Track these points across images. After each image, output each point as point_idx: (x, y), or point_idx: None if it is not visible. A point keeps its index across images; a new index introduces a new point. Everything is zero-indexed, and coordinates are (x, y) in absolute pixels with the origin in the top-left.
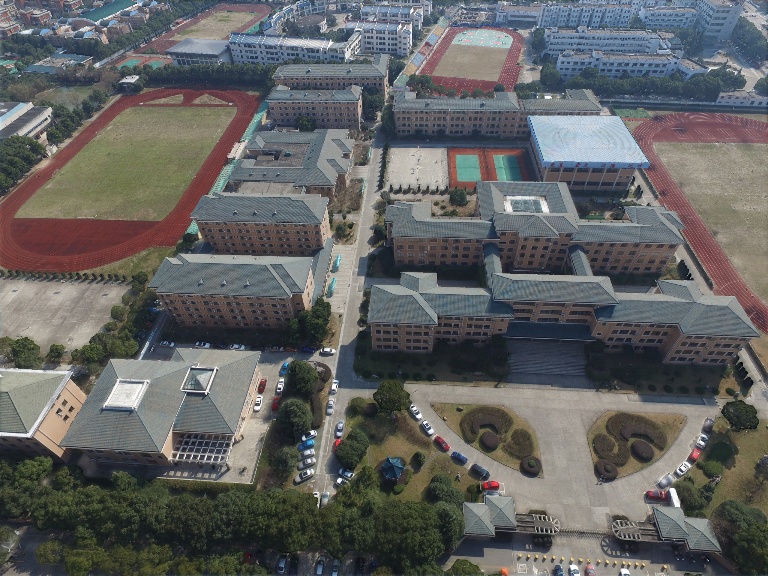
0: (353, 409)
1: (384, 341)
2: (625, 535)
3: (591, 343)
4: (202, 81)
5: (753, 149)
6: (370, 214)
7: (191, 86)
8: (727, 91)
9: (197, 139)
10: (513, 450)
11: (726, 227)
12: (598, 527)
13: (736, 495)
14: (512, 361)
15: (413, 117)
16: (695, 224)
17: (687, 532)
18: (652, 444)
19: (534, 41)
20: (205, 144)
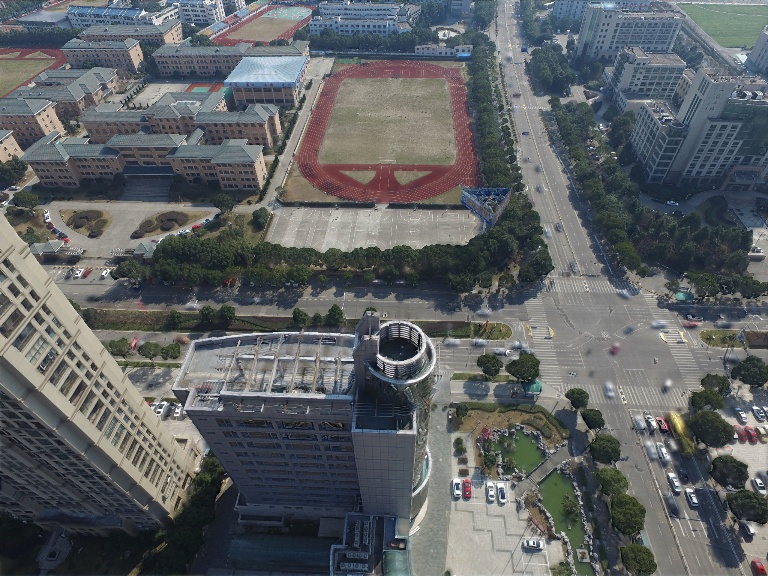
0: (7, 211)
1: (46, 178)
2: (115, 254)
3: (173, 176)
4: (41, 43)
5: (411, 82)
6: None
7: (31, 46)
8: (423, 44)
9: (11, 80)
10: (91, 227)
11: (340, 125)
12: (111, 256)
13: None
14: (126, 190)
15: (169, 61)
16: (321, 123)
17: (147, 250)
18: (177, 224)
19: None
20: (15, 82)
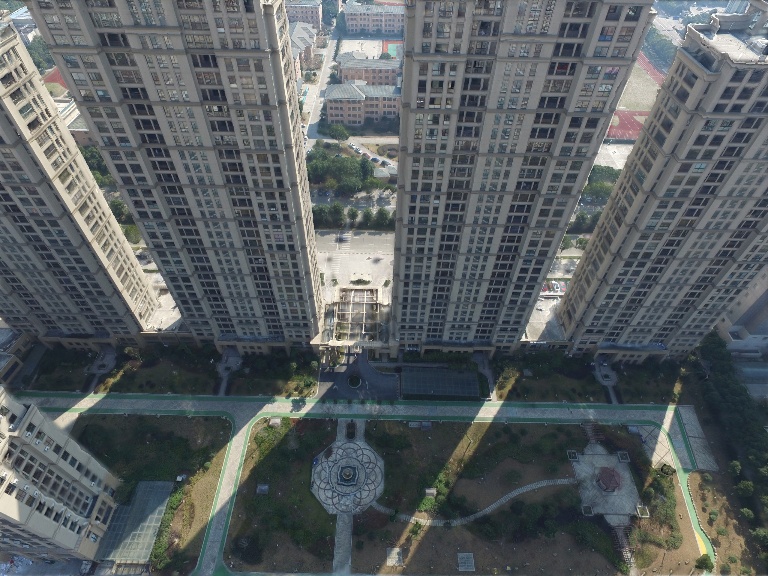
0: (317, 144)
1: (335, 117)
2: None
3: None
4: None
5: None
6: (328, 71)
7: None
8: None
9: None
10: None
11: None
12: None
13: None
14: None
15: (358, 18)
16: None
17: None
18: None
19: None
20: None
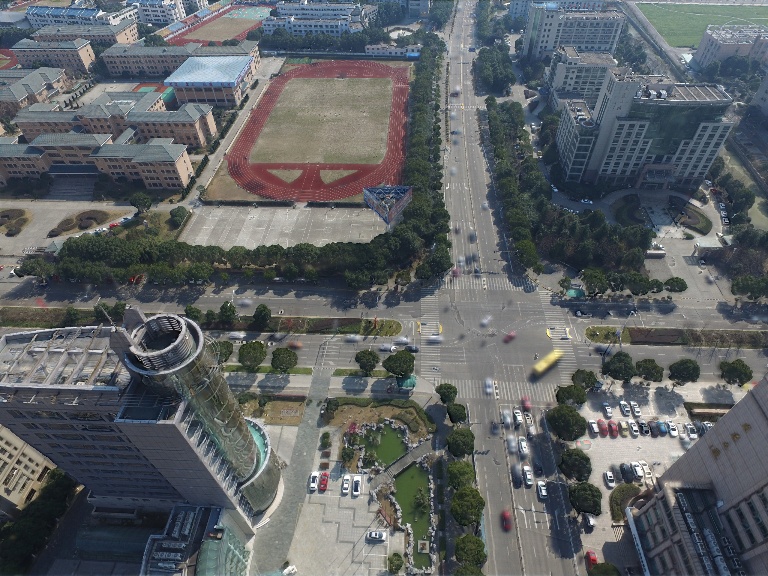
0: None
1: None
2: (26, 252)
3: (98, 175)
4: None
5: (357, 81)
6: None
7: None
8: (374, 44)
9: None
10: (10, 226)
11: (277, 124)
12: (24, 254)
13: None
14: (52, 188)
15: (117, 61)
16: (259, 123)
17: (58, 248)
18: (96, 222)
19: None
20: None
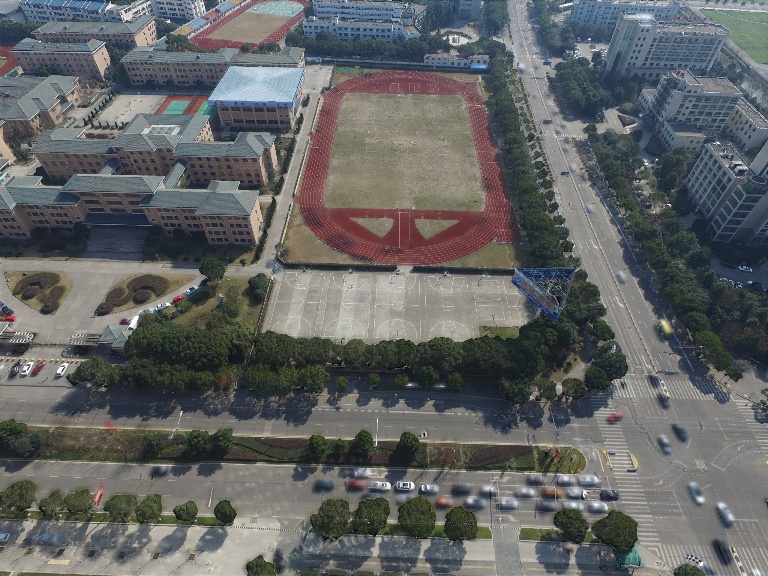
0: None
1: None
2: (74, 342)
3: (148, 227)
4: None
5: (423, 99)
6: None
7: None
8: (433, 53)
9: None
10: (44, 298)
11: (346, 154)
12: None
13: (188, 321)
14: (90, 243)
15: (141, 68)
16: (324, 152)
17: (116, 338)
18: (154, 293)
19: (304, 9)
20: None
